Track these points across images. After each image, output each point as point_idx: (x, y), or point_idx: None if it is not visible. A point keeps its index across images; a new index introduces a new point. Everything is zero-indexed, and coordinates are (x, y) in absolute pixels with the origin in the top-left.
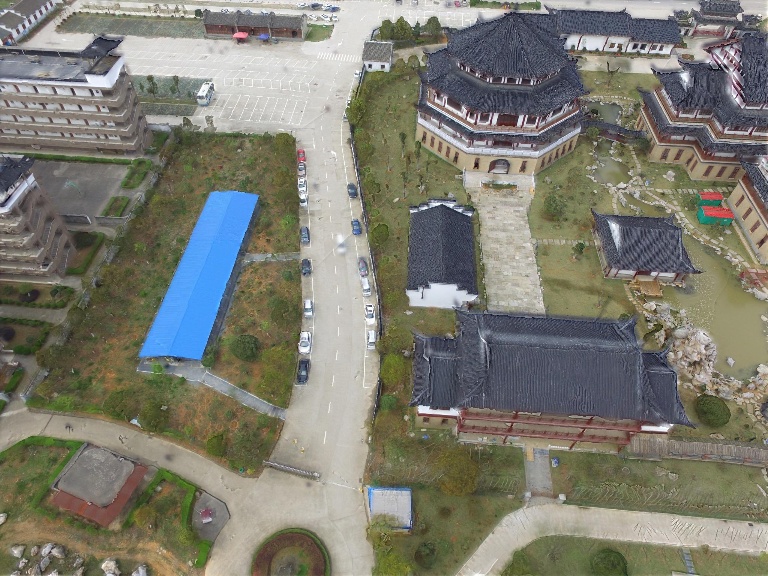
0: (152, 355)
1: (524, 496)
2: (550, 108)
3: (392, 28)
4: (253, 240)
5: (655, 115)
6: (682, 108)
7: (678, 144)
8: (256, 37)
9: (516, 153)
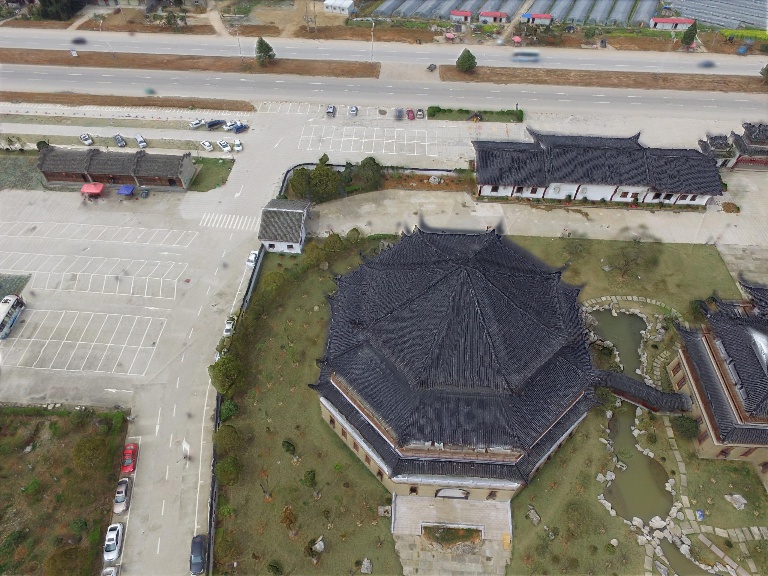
0: None
1: None
2: (535, 428)
3: (307, 180)
4: None
5: (709, 392)
6: (763, 414)
7: (749, 444)
8: (118, 186)
9: (479, 484)
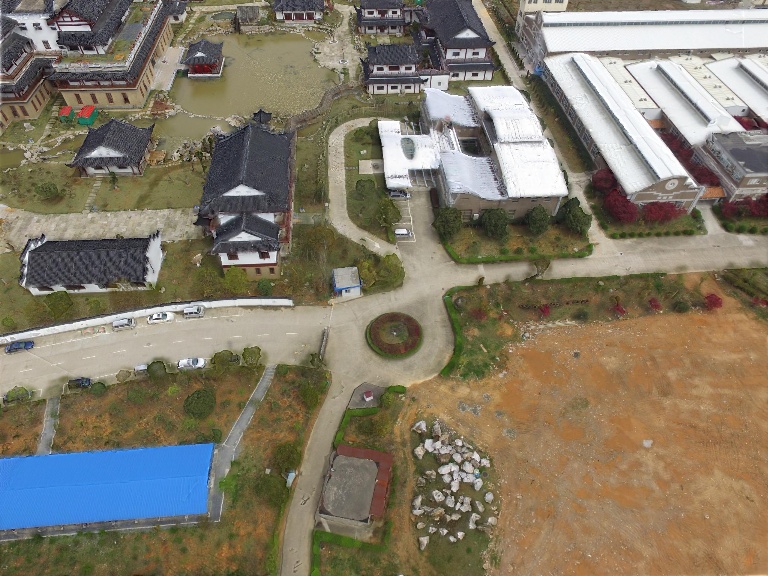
0: (205, 497)
1: (327, 223)
2: None
3: None
4: (9, 457)
5: None
6: None
7: None
8: None
9: None
